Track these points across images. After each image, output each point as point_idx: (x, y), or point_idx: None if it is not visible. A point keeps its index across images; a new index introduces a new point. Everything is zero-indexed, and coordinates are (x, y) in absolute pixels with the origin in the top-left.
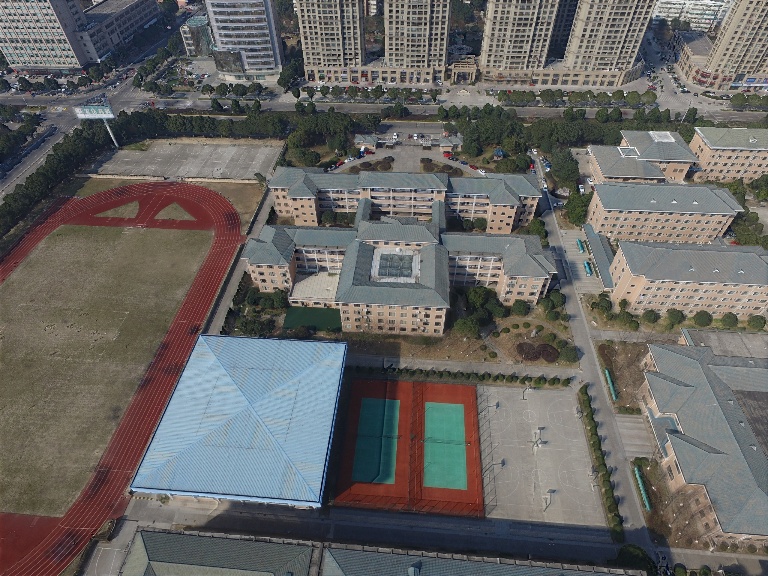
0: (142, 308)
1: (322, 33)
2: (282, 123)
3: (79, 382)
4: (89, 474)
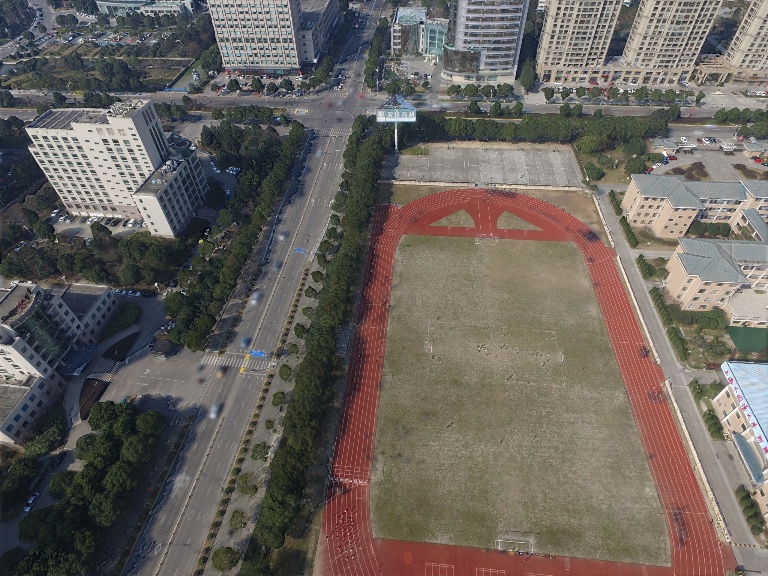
0: (565, 327)
1: (574, 32)
2: None
3: (564, 410)
4: (662, 516)
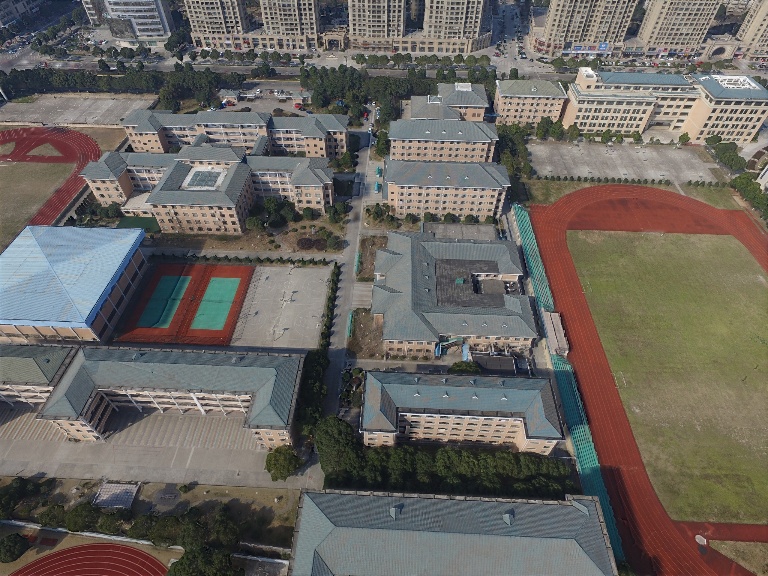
0: None
1: (203, 2)
2: (156, 79)
3: None
4: None
